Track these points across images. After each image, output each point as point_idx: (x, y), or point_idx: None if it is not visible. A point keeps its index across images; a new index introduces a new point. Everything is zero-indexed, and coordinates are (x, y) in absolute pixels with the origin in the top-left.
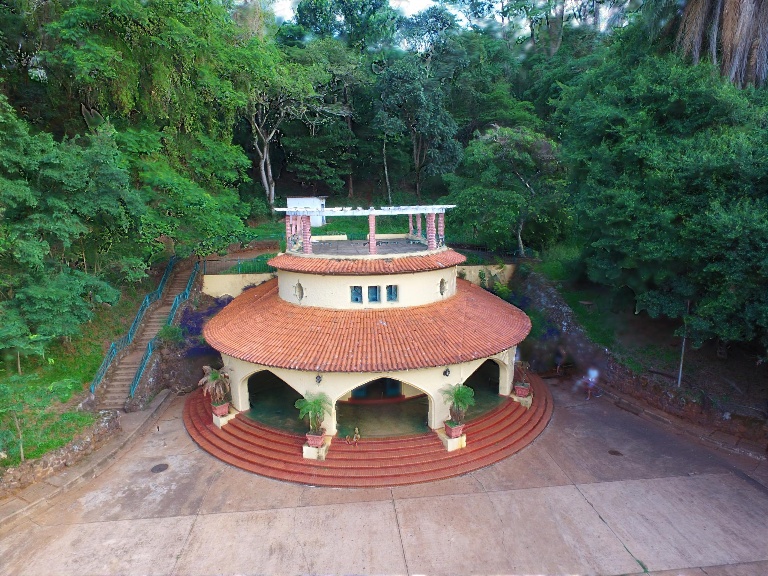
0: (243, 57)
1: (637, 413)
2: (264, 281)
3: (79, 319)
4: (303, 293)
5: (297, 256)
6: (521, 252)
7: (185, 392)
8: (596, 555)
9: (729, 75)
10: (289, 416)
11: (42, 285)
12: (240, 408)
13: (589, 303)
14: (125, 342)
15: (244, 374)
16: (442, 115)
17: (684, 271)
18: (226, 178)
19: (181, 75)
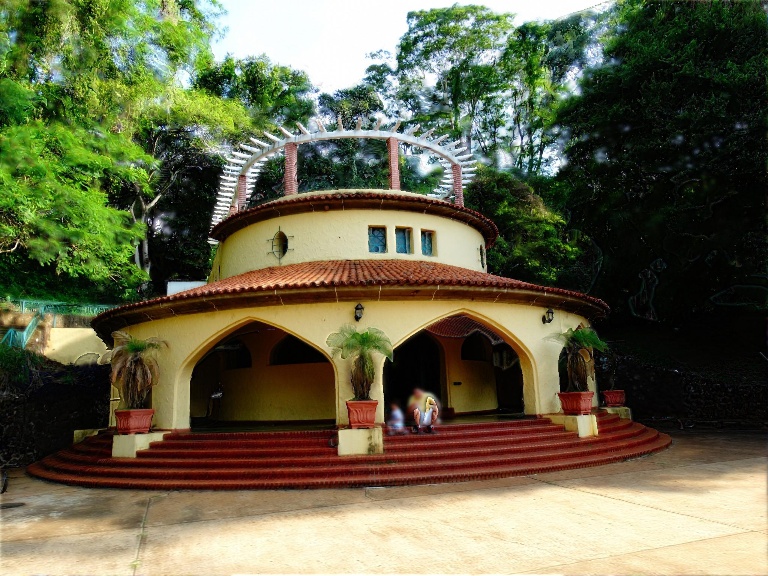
0: (171, 29)
1: (757, 429)
2: None
3: None
4: (287, 245)
5: None
6: None
7: (19, 464)
8: None
9: None
10: (274, 428)
11: None
12: (173, 423)
13: (621, 340)
14: None
15: (195, 344)
16: None
17: None
18: (121, 174)
19: (82, 26)
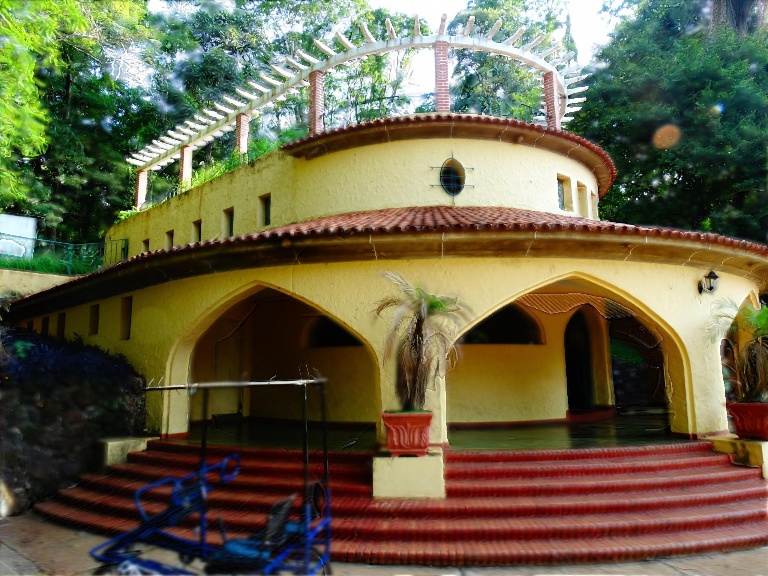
0: None
1: None
2: None
3: None
4: (464, 179)
5: None
6: None
7: (1, 514)
8: None
9: None
10: (557, 437)
11: None
12: (441, 433)
13: None
14: None
15: (485, 305)
16: None
17: None
18: (34, 21)
19: None
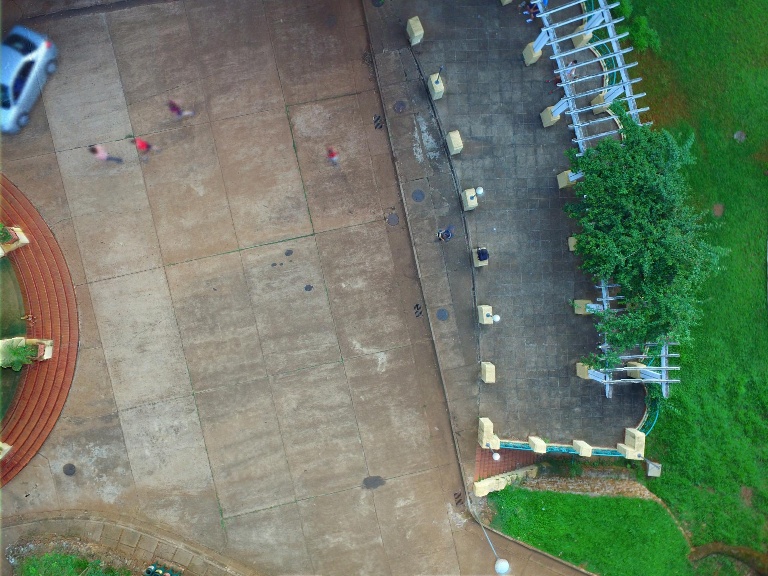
0: None
1: None
2: None
3: None
4: None
5: None
6: None
7: None
8: (124, 161)
9: None
10: None
11: None
12: None
13: None
14: None
15: None
16: None
17: None
18: None
19: None
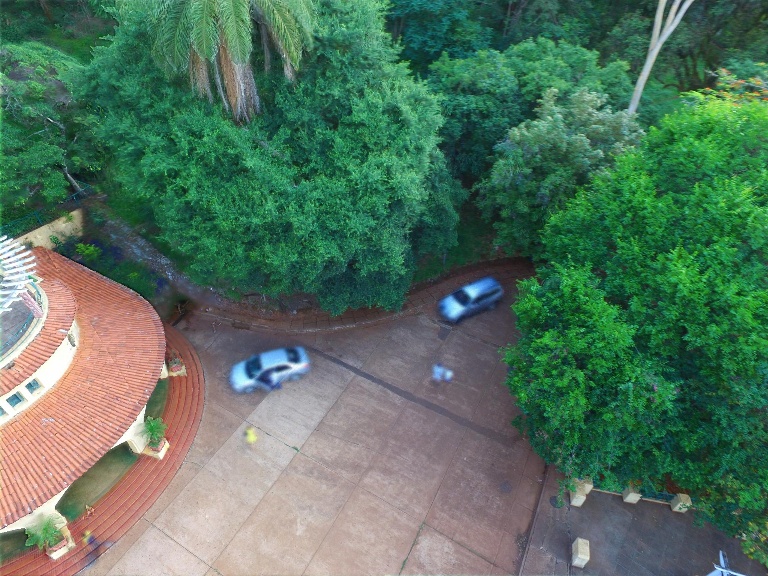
0: None
1: (248, 328)
2: None
3: None
4: None
5: None
6: (78, 190)
7: None
8: (276, 460)
9: (236, 108)
10: None
11: None
12: None
13: None
14: None
15: None
16: None
17: None
18: None
19: None
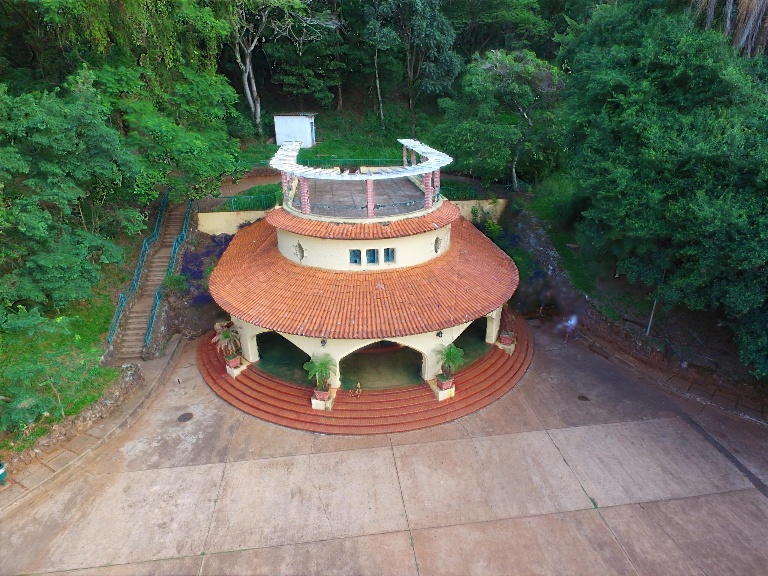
0: None
1: (607, 357)
2: (259, 219)
3: (89, 281)
4: (303, 253)
5: (296, 215)
6: (514, 185)
7: (195, 336)
8: (558, 494)
9: (740, 38)
10: (296, 367)
11: (48, 250)
12: (251, 360)
13: (575, 246)
14: (131, 289)
15: (253, 333)
16: (439, 22)
17: (664, 244)
18: (213, 115)
19: (155, 1)
